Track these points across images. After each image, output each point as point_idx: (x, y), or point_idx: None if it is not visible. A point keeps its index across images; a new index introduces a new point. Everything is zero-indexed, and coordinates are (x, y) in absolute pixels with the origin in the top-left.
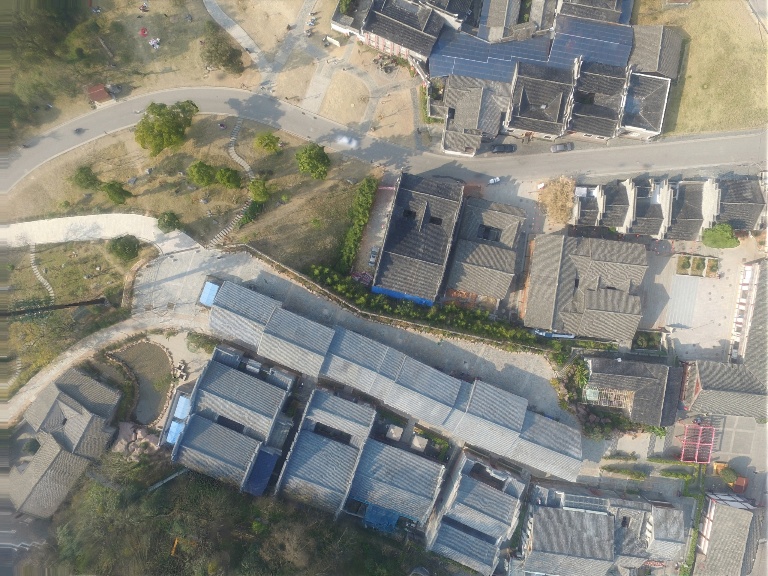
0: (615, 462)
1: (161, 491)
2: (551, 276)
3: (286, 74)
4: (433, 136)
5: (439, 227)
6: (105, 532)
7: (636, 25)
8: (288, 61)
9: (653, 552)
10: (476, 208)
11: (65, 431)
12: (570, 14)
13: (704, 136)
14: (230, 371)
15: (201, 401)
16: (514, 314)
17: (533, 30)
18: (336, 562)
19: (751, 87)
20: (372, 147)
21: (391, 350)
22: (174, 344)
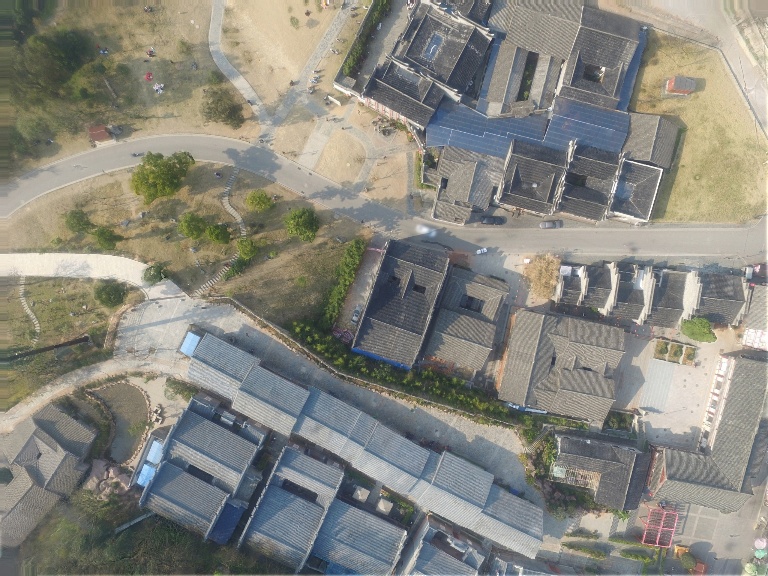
0: (577, 539)
1: (126, 536)
2: (528, 353)
3: (285, 128)
4: (425, 201)
5: (422, 295)
6: (68, 572)
7: (633, 113)
8: (288, 116)
9: None
10: (460, 279)
11: (39, 465)
12: (569, 97)
13: (692, 226)
14: (204, 422)
15: (173, 449)
16: (490, 383)
17: (531, 109)
18: None
19: (742, 182)
20: (364, 207)
21: (364, 415)
22: (153, 388)
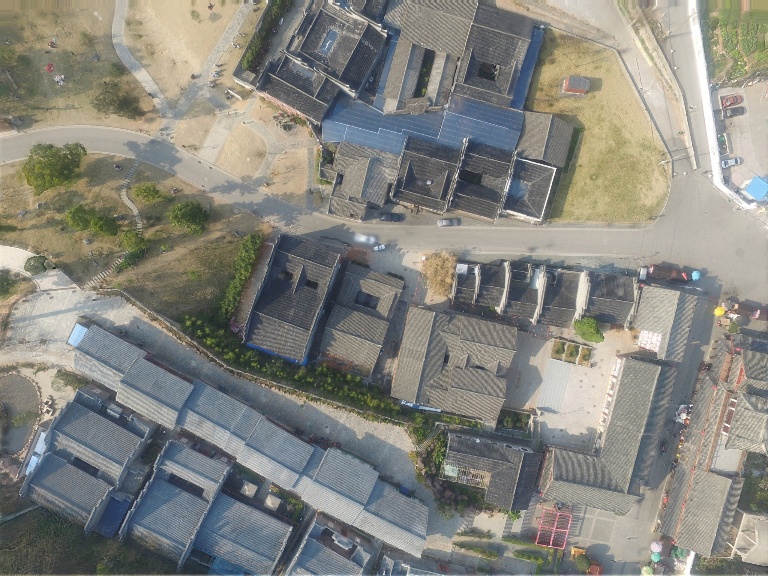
0: (469, 539)
1: (5, 527)
2: (419, 350)
3: (186, 122)
4: (325, 197)
5: (314, 291)
6: None
7: (528, 111)
8: (190, 109)
9: None
10: (354, 275)
11: None
12: (463, 94)
13: (589, 226)
14: (89, 414)
15: (57, 441)
16: (389, 380)
17: (426, 106)
18: None
19: (638, 183)
20: (264, 202)
21: (249, 410)
22: (44, 379)
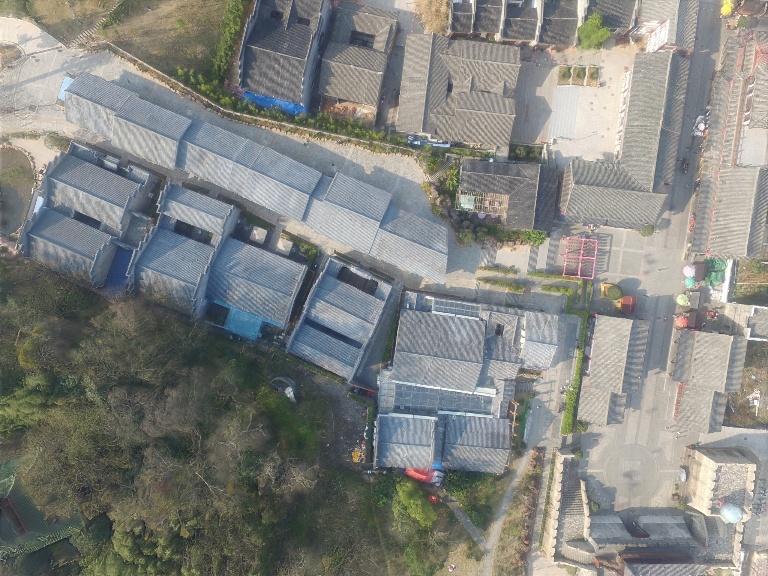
0: (493, 274)
1: (6, 280)
2: (421, 76)
3: None
4: None
5: (307, 27)
6: None
7: None
8: None
9: (527, 359)
10: (346, 10)
11: None
12: None
13: None
14: (85, 164)
15: (54, 194)
16: (393, 130)
17: None
18: (183, 351)
19: None
20: None
21: (250, 142)
22: (36, 148)
